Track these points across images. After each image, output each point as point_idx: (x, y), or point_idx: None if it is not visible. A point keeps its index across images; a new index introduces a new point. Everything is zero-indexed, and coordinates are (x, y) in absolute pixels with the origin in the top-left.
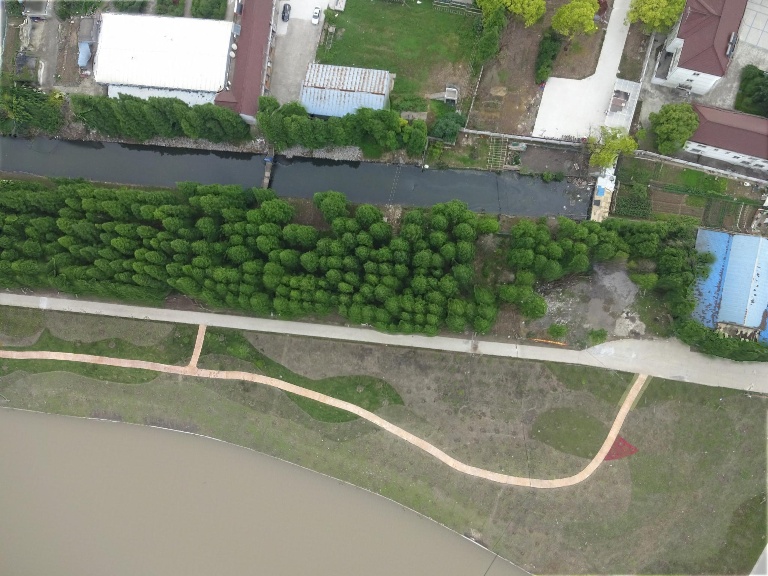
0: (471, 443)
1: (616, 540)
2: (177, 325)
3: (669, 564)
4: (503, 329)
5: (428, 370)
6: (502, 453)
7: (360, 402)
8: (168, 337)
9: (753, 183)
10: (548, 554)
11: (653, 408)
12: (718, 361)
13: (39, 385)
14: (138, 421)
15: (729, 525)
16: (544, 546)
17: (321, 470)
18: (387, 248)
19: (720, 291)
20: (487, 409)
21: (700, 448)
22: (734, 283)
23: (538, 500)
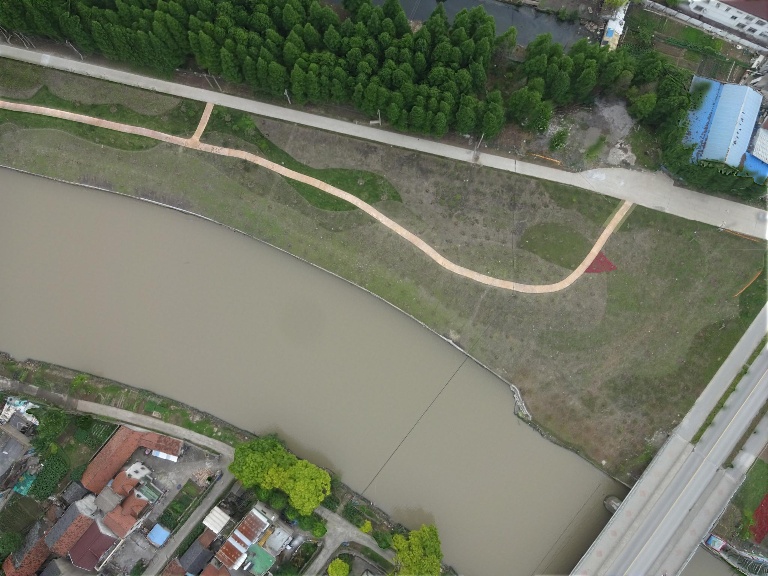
0: (462, 246)
1: (586, 352)
2: (184, 100)
3: (631, 378)
4: (505, 144)
5: (429, 174)
6: (490, 257)
7: (360, 194)
8: (173, 110)
9: (745, 47)
10: (521, 360)
11: (634, 233)
12: (697, 197)
13: (28, 142)
14: (129, 191)
15: (690, 346)
16: (518, 352)
17: (311, 260)
18: (410, 37)
19: (707, 132)
20: (481, 217)
21: (672, 275)
22: (720, 125)
23: (519, 304)
